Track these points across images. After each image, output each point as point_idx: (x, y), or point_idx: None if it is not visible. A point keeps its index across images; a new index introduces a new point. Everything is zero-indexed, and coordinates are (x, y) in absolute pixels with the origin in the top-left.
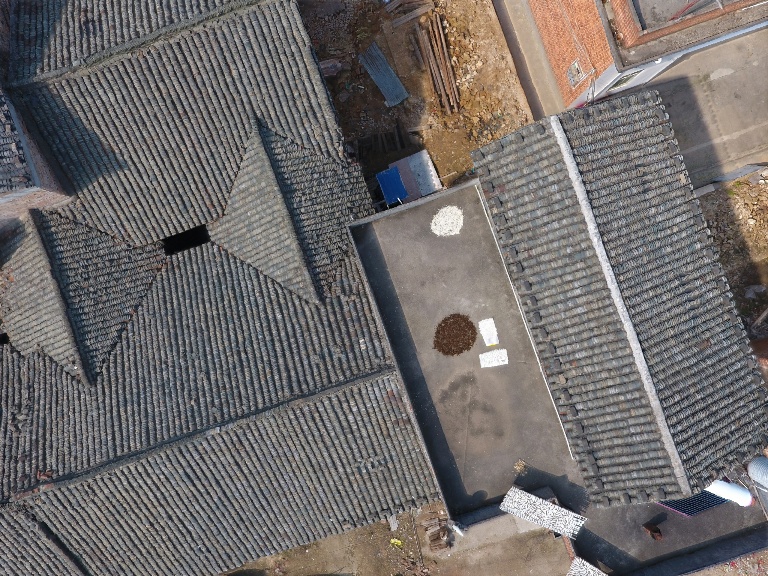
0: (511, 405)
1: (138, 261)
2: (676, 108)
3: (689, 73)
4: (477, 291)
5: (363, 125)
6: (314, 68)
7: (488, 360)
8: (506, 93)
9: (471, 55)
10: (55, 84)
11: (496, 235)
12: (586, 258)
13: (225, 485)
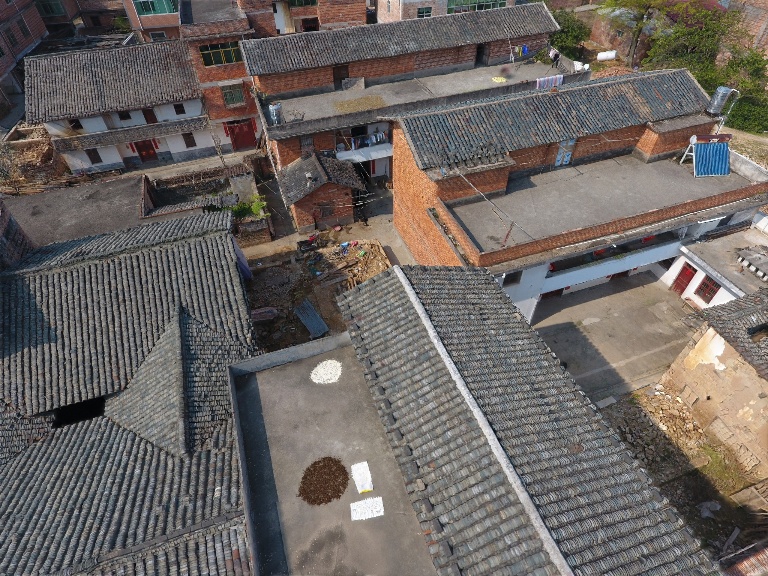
0: (388, 572)
1: (19, 430)
2: (562, 344)
3: (564, 321)
4: (351, 434)
5: None
6: (236, 274)
7: (360, 511)
8: None
9: None
10: (30, 278)
11: None
12: (431, 358)
13: None
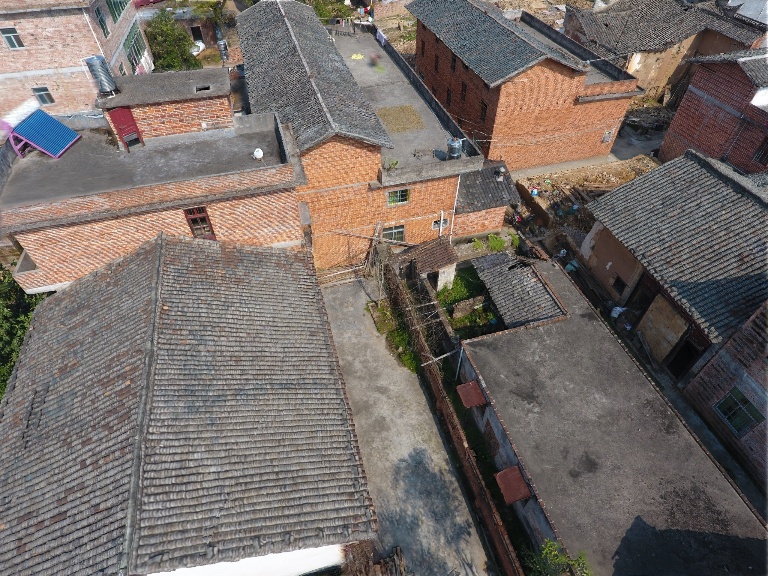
0: None
1: None
2: None
3: None
4: None
5: None
6: None
7: None
8: None
9: None
10: None
11: (766, 110)
12: None
13: None
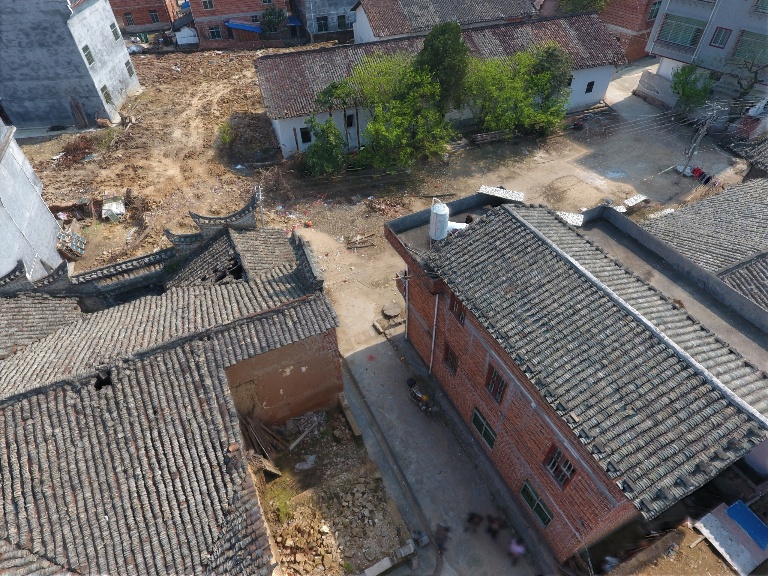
0: None
1: None
2: None
3: None
4: None
5: None
6: None
7: None
8: None
9: None
10: None
11: None
12: None
13: (760, 220)
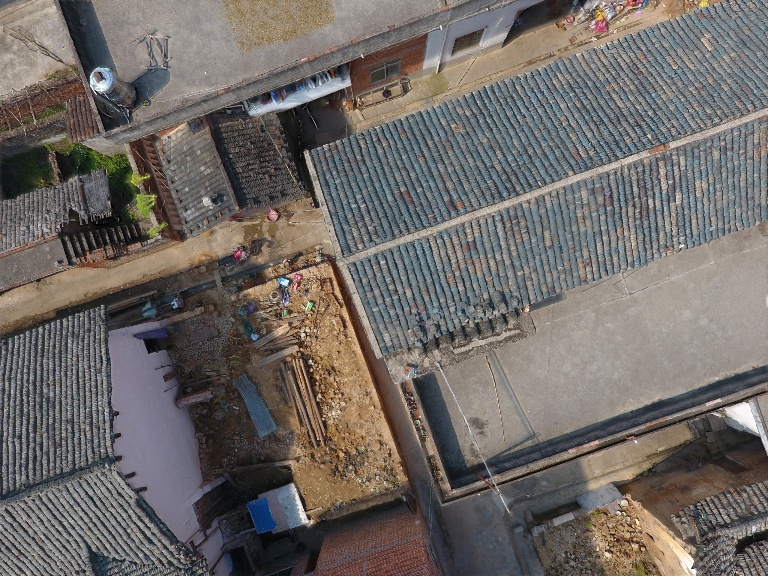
0: None
1: None
2: None
3: None
4: None
5: (237, 447)
6: (142, 516)
7: None
8: (370, 429)
9: (336, 392)
10: None
11: None
12: None
13: None
